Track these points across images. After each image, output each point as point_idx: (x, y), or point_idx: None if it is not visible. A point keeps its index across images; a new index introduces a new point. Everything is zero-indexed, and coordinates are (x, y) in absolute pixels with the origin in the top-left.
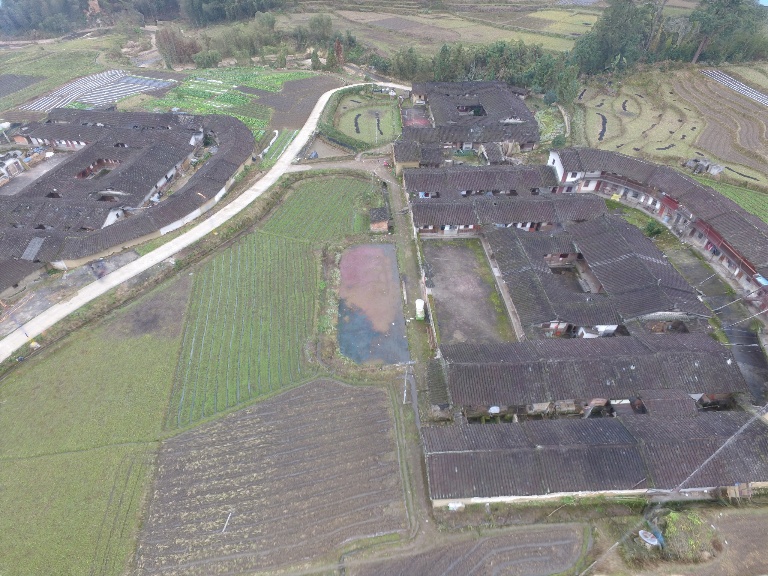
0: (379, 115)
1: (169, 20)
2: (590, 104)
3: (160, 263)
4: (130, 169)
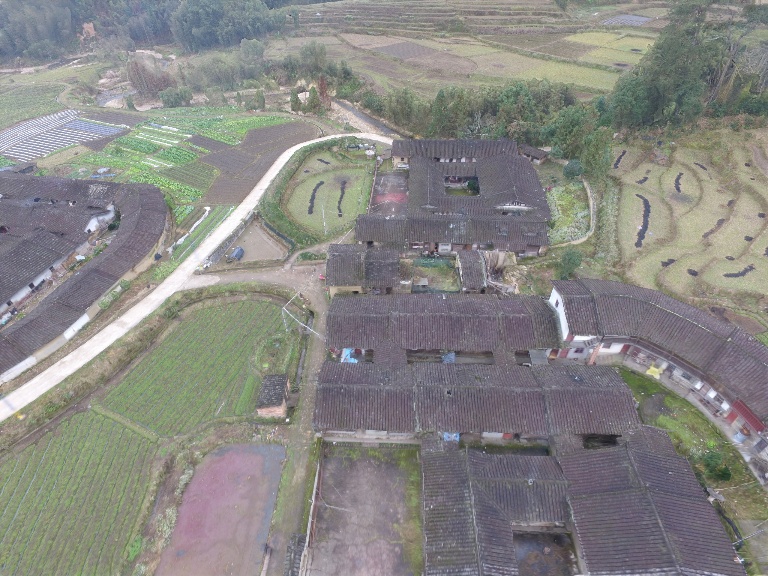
0: (346, 184)
1: (167, 43)
2: (628, 178)
3: None
4: None
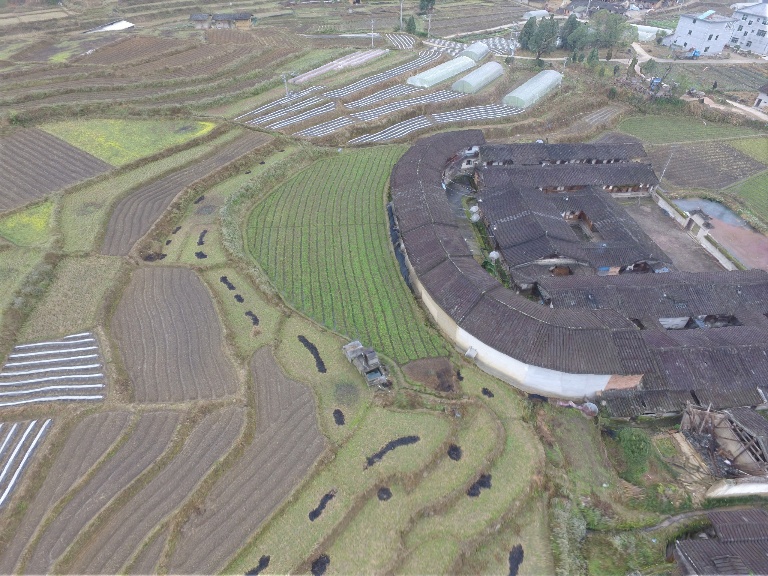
0: None
1: None
2: None
3: None
4: None
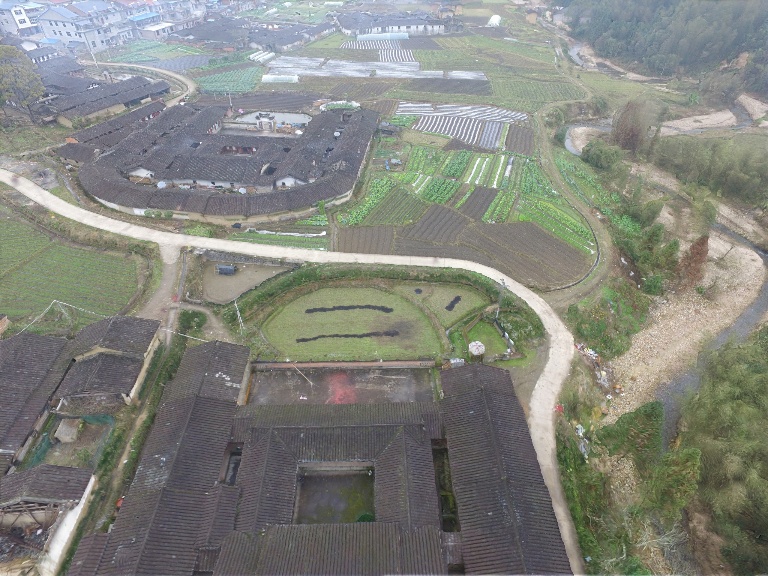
0: (388, 336)
1: None
2: None
3: (30, 200)
4: (201, 158)
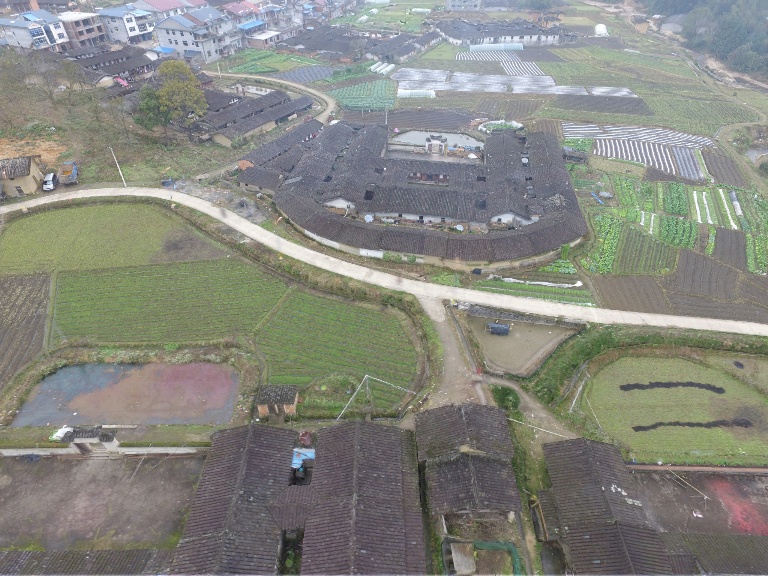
0: (741, 427)
1: None
2: None
3: (244, 235)
4: (405, 189)
